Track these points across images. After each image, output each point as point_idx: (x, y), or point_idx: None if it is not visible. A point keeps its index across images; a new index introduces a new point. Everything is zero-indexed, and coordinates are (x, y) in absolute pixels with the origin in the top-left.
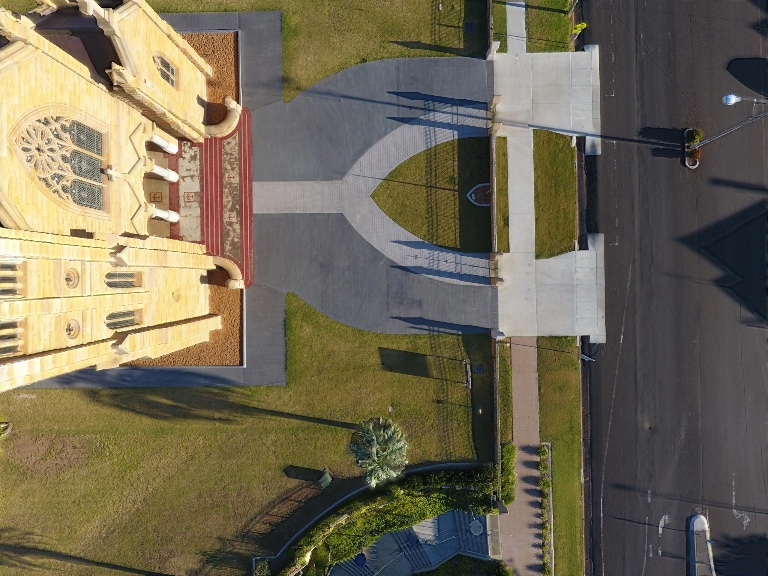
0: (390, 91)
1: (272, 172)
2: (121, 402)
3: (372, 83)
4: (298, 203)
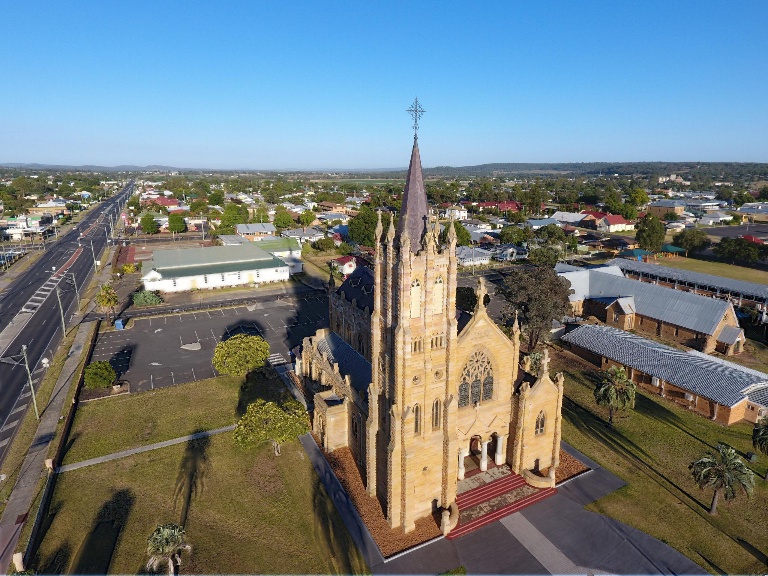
0: (671, 570)
1: (535, 519)
2: (318, 499)
3: (660, 554)
4: (532, 544)
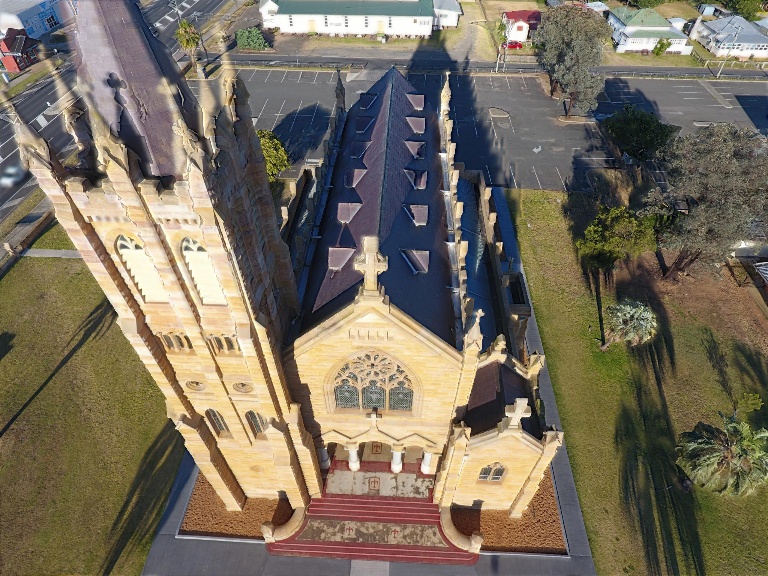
0: None
1: None
2: None
3: None
4: None
